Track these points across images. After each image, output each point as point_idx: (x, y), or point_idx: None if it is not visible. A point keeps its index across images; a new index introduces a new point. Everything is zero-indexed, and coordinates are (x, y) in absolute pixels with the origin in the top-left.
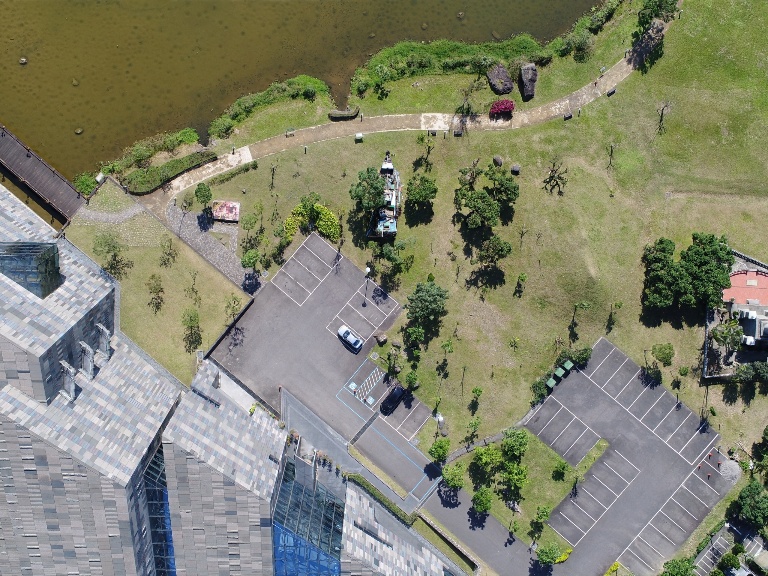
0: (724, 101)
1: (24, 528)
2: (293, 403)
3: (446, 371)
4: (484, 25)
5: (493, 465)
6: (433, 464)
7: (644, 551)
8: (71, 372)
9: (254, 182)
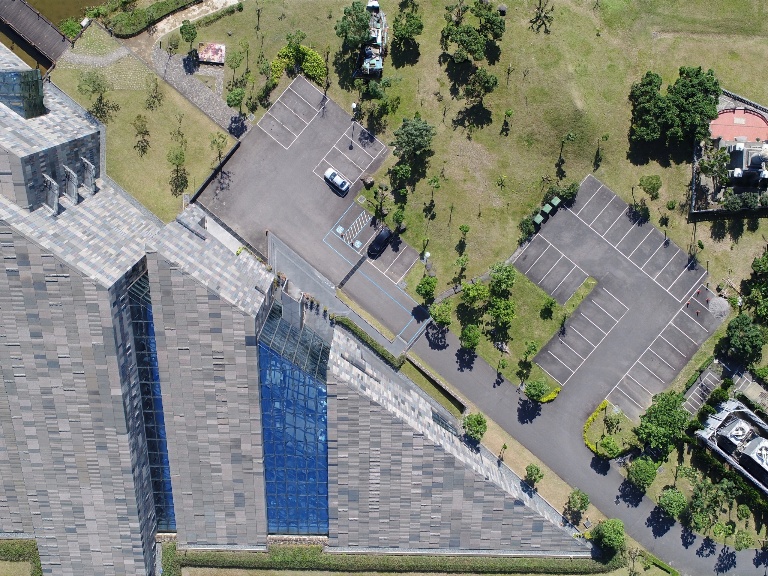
0: None
1: (7, 336)
2: (280, 247)
3: (433, 212)
4: None
5: (481, 306)
6: (421, 307)
7: (633, 389)
8: (54, 186)
9: (240, 24)
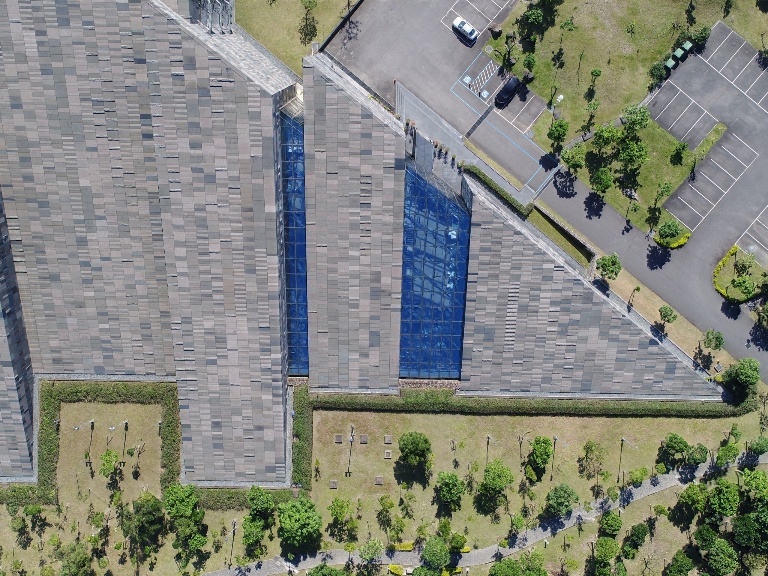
0: None
1: (166, 147)
2: (408, 95)
3: (562, 60)
4: None
5: (610, 153)
6: (548, 156)
7: (763, 234)
8: (208, 5)
9: None
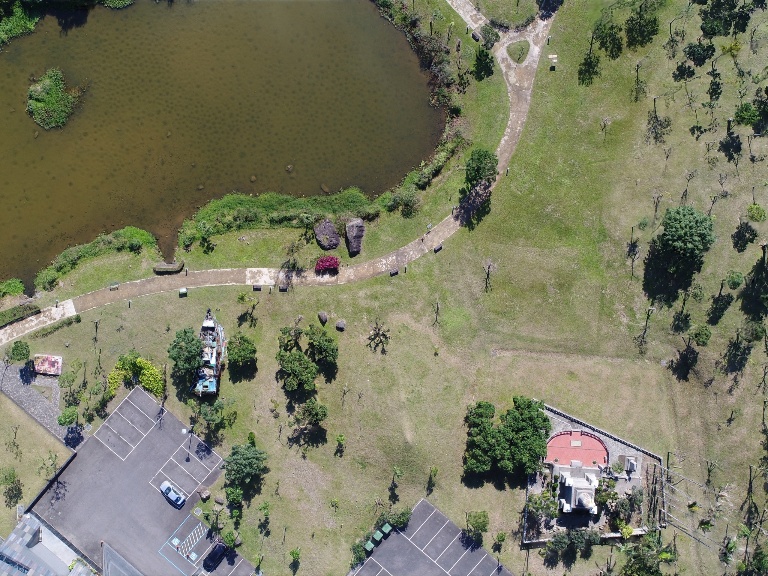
0: (551, 259)
1: None
2: (114, 559)
3: (268, 529)
4: (313, 178)
5: None
6: None
7: None
8: None
9: (77, 335)
